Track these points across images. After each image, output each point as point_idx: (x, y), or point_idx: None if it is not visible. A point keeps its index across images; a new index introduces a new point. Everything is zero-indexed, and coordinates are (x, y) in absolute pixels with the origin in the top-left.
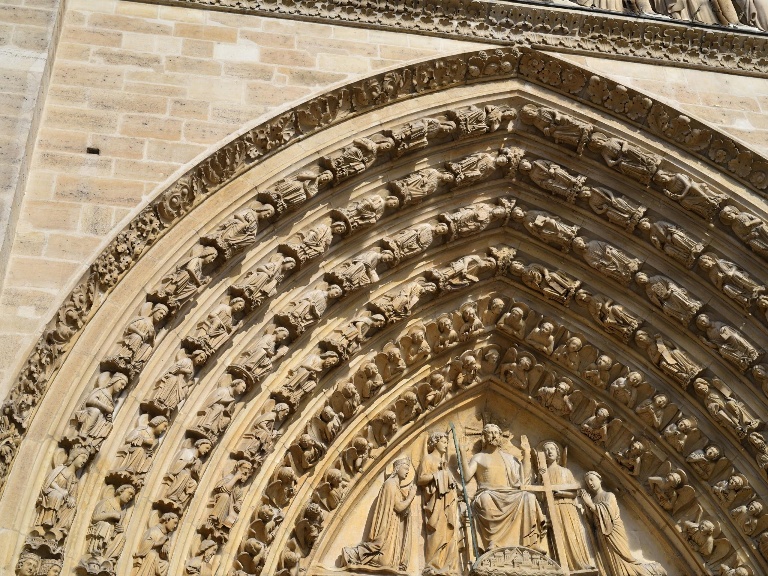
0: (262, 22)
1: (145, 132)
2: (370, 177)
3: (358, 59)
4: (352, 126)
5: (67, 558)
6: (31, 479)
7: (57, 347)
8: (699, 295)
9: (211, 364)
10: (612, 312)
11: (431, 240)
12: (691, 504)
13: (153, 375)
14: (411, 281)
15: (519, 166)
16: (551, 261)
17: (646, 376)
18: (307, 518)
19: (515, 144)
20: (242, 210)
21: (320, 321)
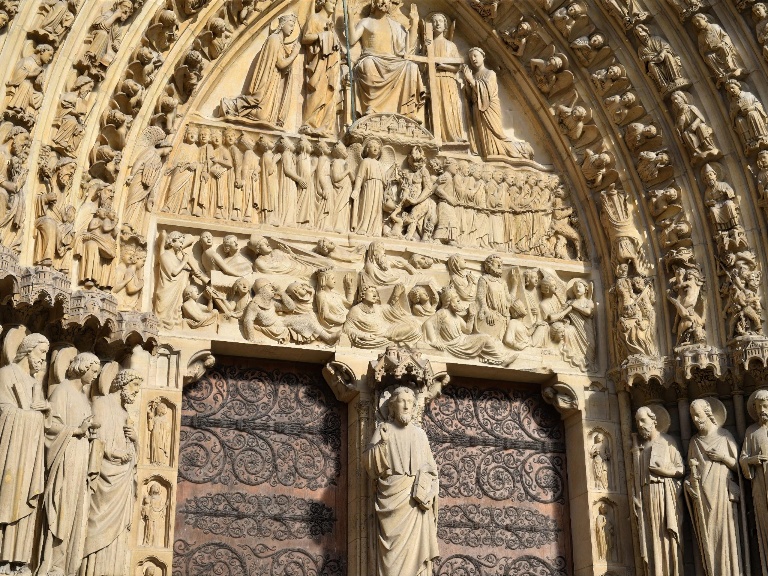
0: None
1: None
2: None
3: None
4: None
5: None
6: None
7: None
8: None
9: None
10: None
11: None
12: (568, 89)
13: None
14: None
15: None
16: None
17: None
18: (187, 65)
19: None
20: None
21: None
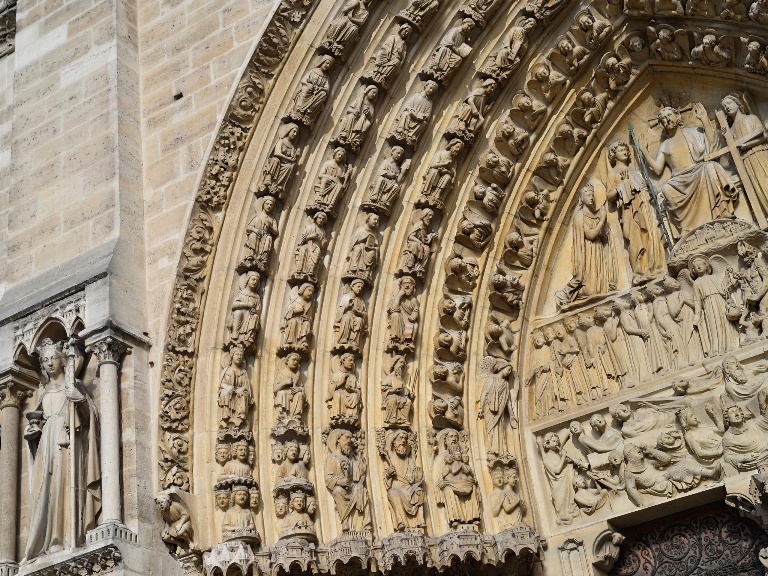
0: None
1: (209, 56)
2: None
3: None
4: None
5: (262, 430)
6: (209, 388)
7: (195, 277)
8: None
9: (344, 213)
10: None
11: None
12: None
13: (290, 253)
14: (510, 28)
15: None
16: None
17: None
18: (498, 289)
19: None
20: (305, 74)
21: (435, 118)
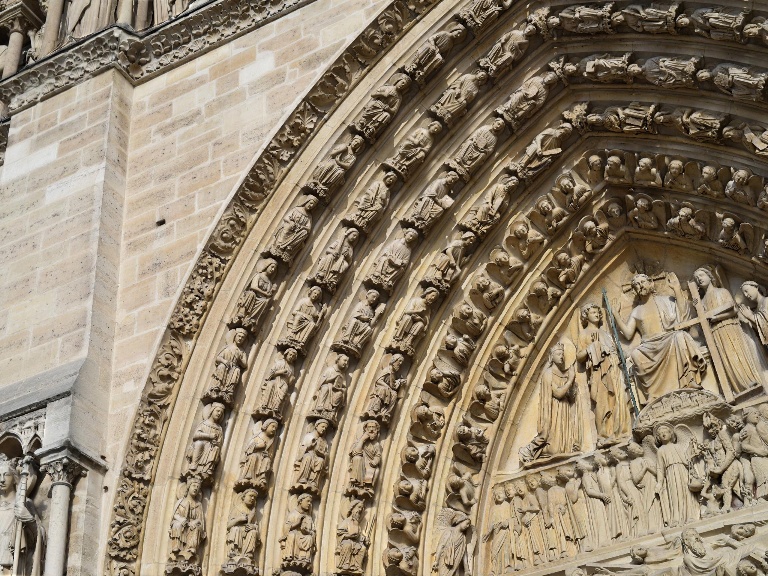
0: (274, 27)
1: (195, 186)
2: (407, 115)
3: (354, 17)
4: (369, 81)
5: (212, 566)
6: (161, 518)
7: (159, 404)
8: (765, 65)
9: (315, 351)
10: (691, 122)
11: (494, 139)
12: None
13: (257, 387)
14: (493, 185)
15: (548, 26)
16: (623, 97)
17: (754, 169)
18: (462, 440)
19: (540, 6)
20: (288, 212)
21: (412, 265)
